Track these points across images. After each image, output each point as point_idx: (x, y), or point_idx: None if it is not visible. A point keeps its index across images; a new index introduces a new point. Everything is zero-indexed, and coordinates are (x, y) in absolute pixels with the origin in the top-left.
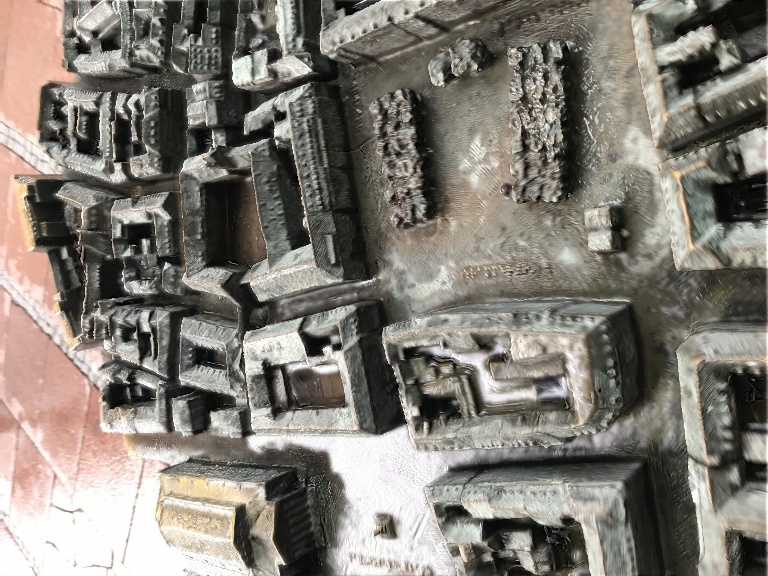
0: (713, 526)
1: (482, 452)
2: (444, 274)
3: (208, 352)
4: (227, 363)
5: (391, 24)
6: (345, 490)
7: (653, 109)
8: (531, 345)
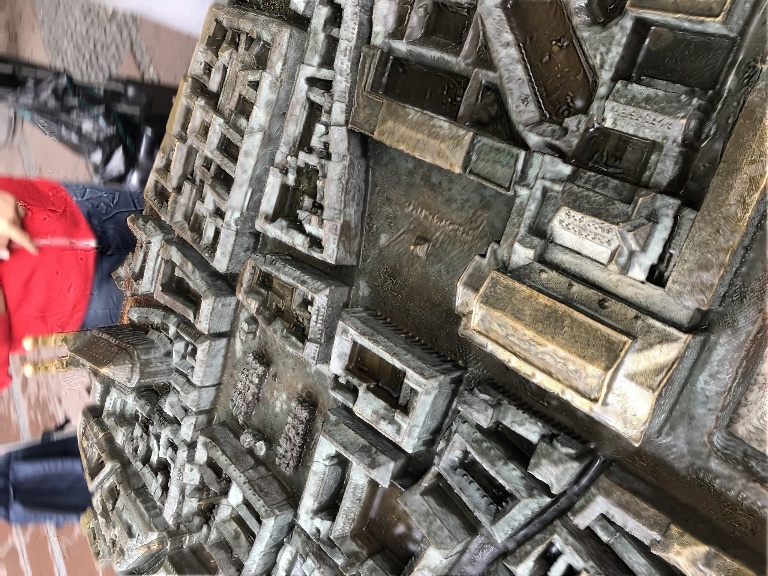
0: (234, 203)
1: (338, 266)
2: (313, 369)
3: (500, 492)
4: (445, 452)
5: (249, 483)
6: (444, 289)
7: (203, 352)
8: (250, 303)
